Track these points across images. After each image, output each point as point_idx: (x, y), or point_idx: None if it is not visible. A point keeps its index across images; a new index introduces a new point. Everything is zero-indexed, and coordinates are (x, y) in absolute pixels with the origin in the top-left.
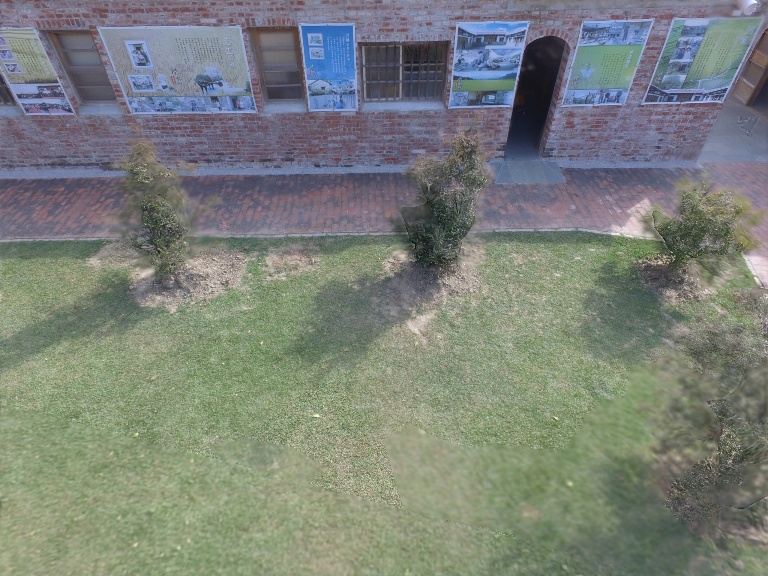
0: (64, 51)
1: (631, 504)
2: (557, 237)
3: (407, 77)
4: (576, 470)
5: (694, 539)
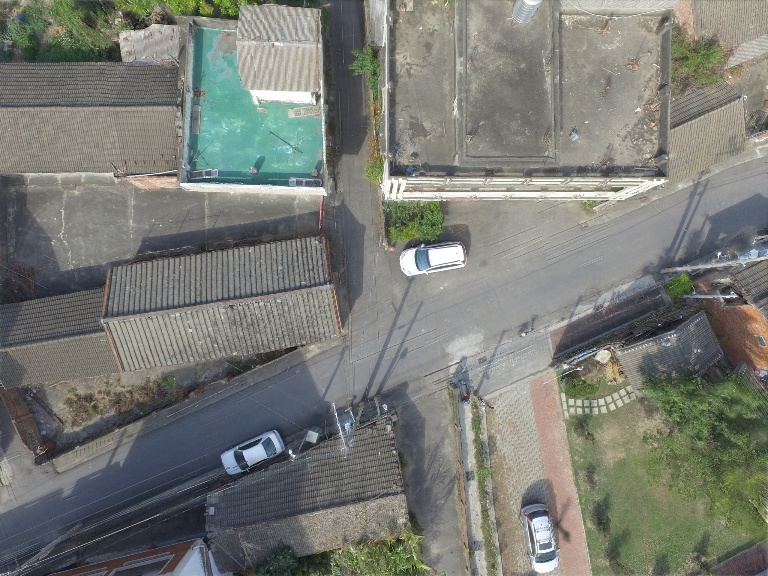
0: None
1: (617, 552)
2: None
3: None
4: (623, 554)
5: (610, 551)
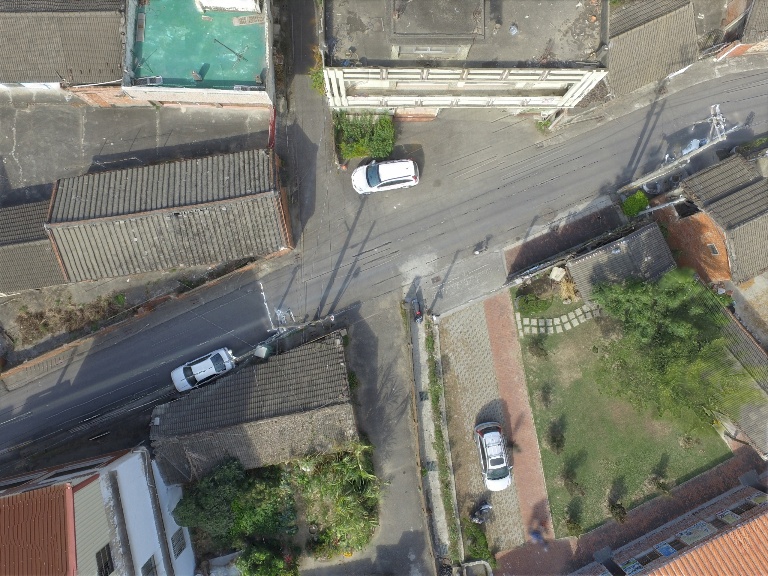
0: None
1: (573, 473)
2: (590, 529)
3: None
4: (580, 475)
5: (566, 472)
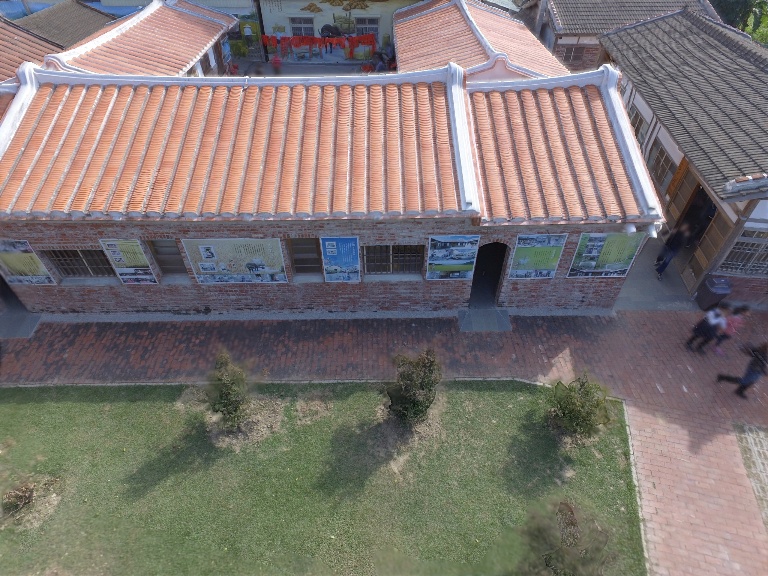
0: (155, 248)
1: None
2: (499, 386)
3: (396, 261)
4: None
5: None
